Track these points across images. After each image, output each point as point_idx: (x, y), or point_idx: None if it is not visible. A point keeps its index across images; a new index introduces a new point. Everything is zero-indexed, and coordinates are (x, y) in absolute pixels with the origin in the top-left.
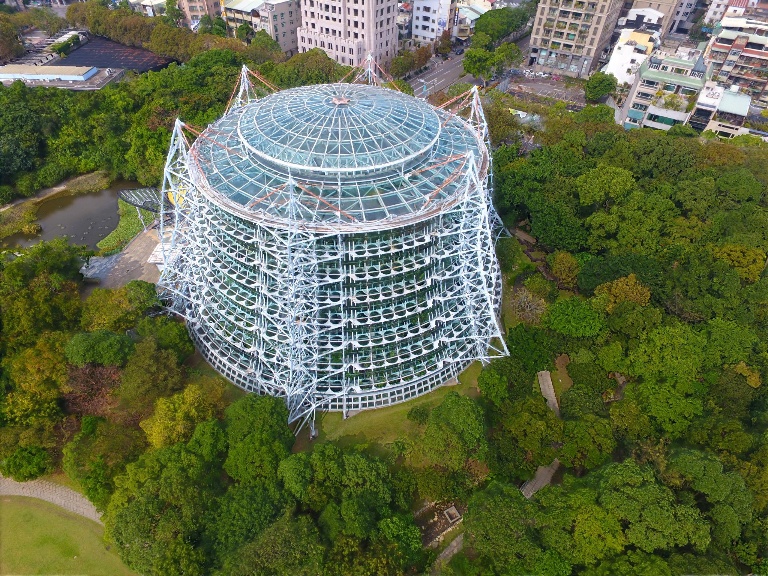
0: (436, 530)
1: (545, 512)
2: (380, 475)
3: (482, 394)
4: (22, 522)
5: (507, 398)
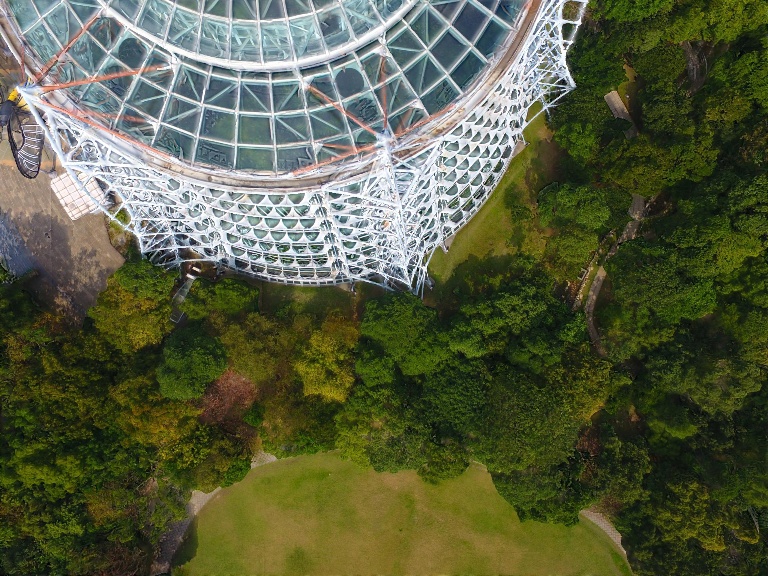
0: (573, 292)
1: (687, 255)
2: (530, 296)
3: (574, 158)
4: (266, 486)
5: (594, 144)
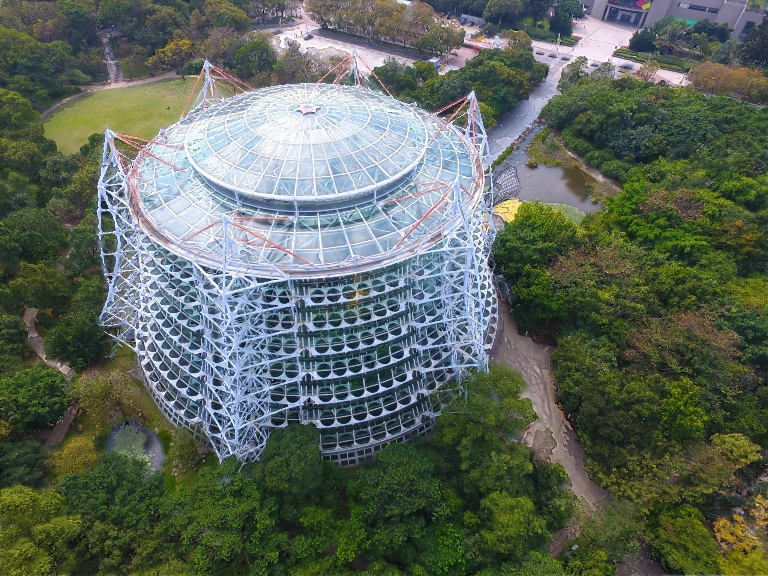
0: None
1: (5, 233)
2: None
3: None
4: None
5: None
